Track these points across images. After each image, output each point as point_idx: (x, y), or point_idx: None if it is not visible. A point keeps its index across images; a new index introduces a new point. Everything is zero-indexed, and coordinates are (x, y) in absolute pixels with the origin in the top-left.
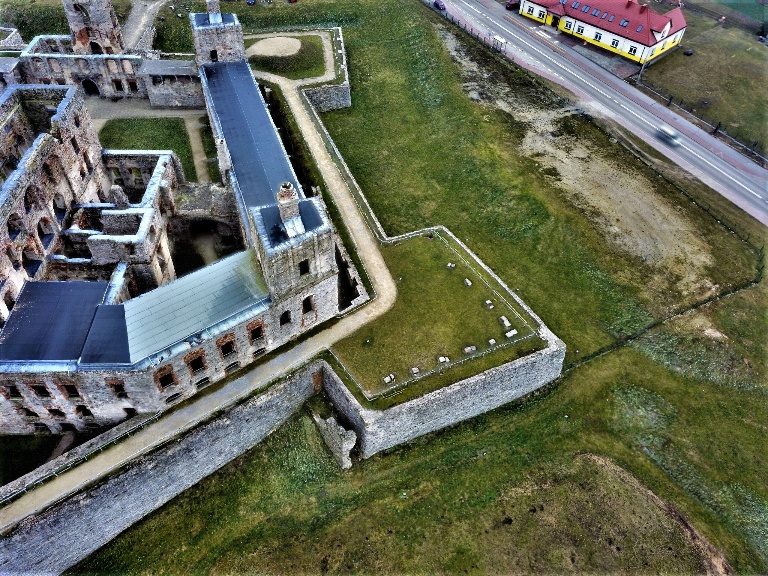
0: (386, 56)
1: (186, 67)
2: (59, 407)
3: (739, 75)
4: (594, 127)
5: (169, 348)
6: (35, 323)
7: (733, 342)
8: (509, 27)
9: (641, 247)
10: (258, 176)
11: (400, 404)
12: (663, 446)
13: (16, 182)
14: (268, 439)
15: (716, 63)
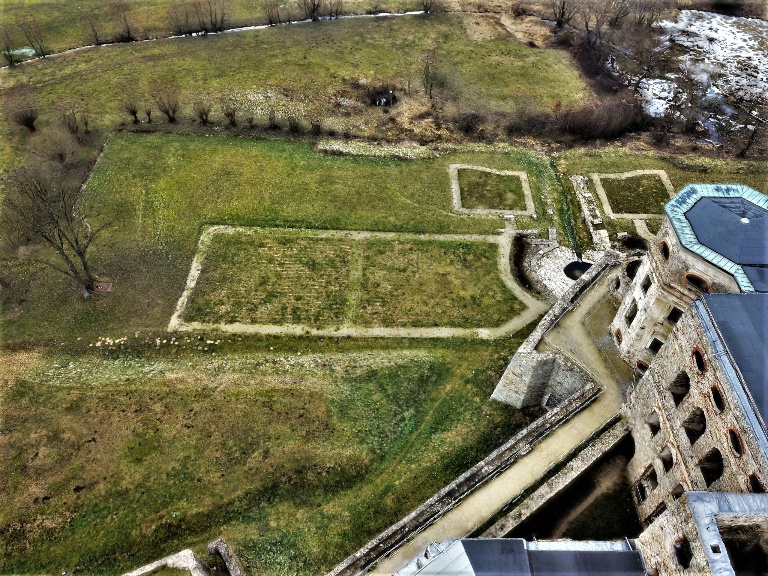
0: None
1: None
2: None
3: None
4: None
5: None
6: None
7: None
8: None
9: None
10: None
11: (141, 574)
12: None
13: None
14: None
15: None
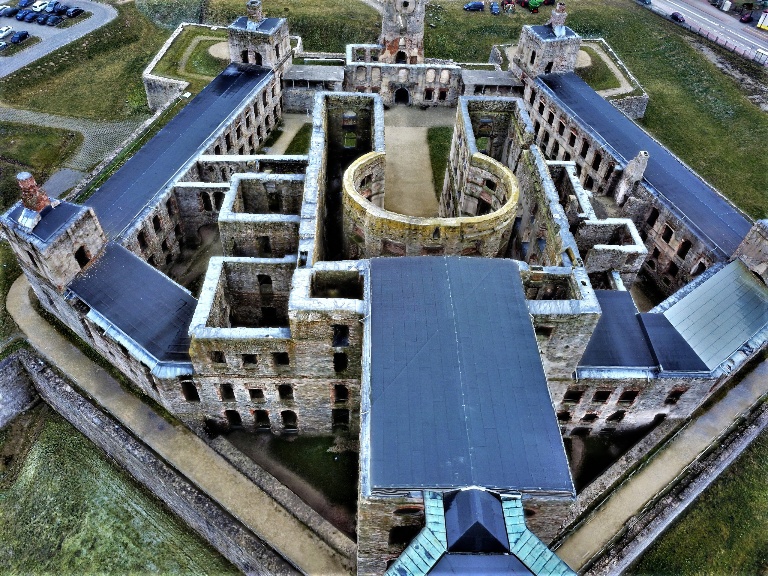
0: (647, 67)
1: (506, 77)
2: (600, 412)
3: None
4: None
5: None
6: None
7: None
8: (754, 40)
9: None
10: (678, 188)
11: None
12: None
13: None
14: (751, 445)
15: None
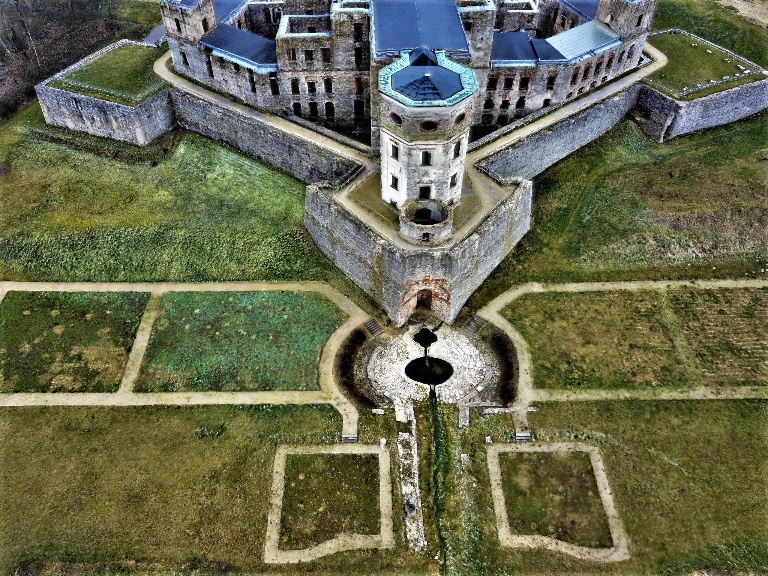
0: None
1: None
2: (510, 98)
3: None
4: None
5: (581, 56)
6: (501, 48)
7: None
8: None
9: None
10: None
11: (697, 98)
12: None
13: None
14: (609, 132)
15: None
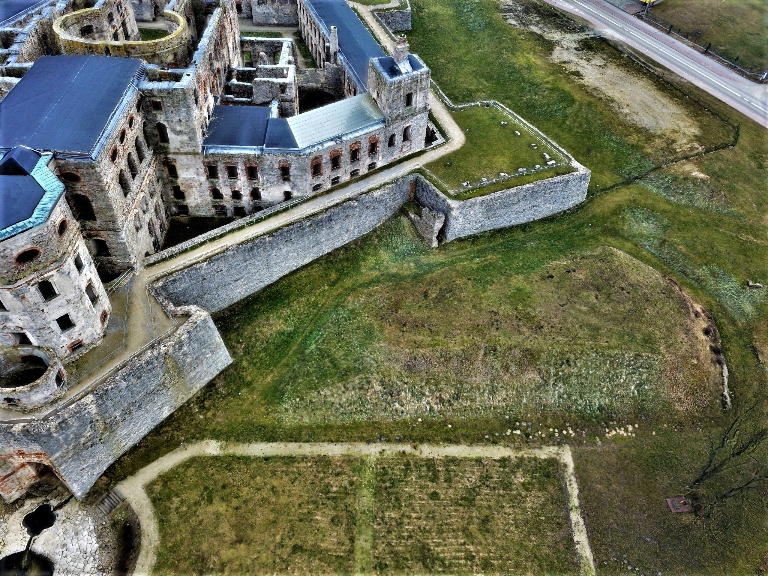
0: None
1: None
2: (240, 189)
3: (727, 14)
4: (609, 46)
5: (322, 143)
6: (227, 127)
7: (713, 180)
8: None
9: (646, 122)
10: (361, 55)
11: (475, 197)
12: (660, 244)
13: (212, 32)
14: (377, 229)
15: (709, 6)
